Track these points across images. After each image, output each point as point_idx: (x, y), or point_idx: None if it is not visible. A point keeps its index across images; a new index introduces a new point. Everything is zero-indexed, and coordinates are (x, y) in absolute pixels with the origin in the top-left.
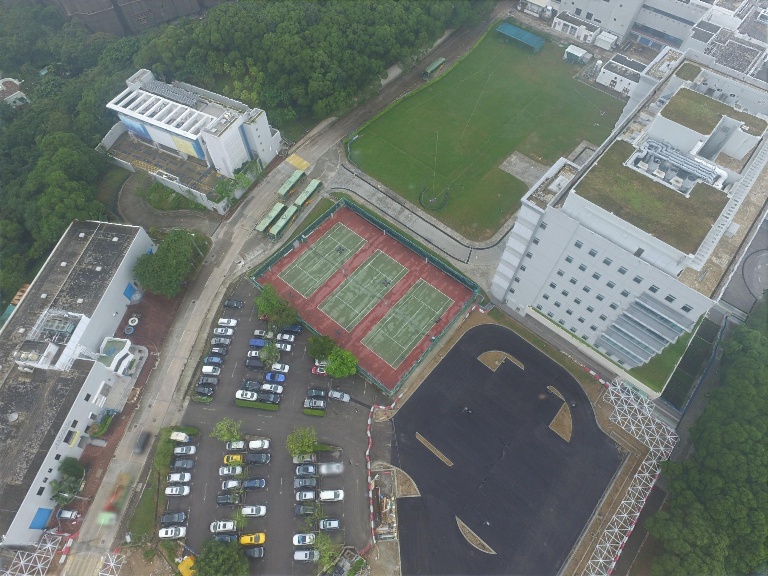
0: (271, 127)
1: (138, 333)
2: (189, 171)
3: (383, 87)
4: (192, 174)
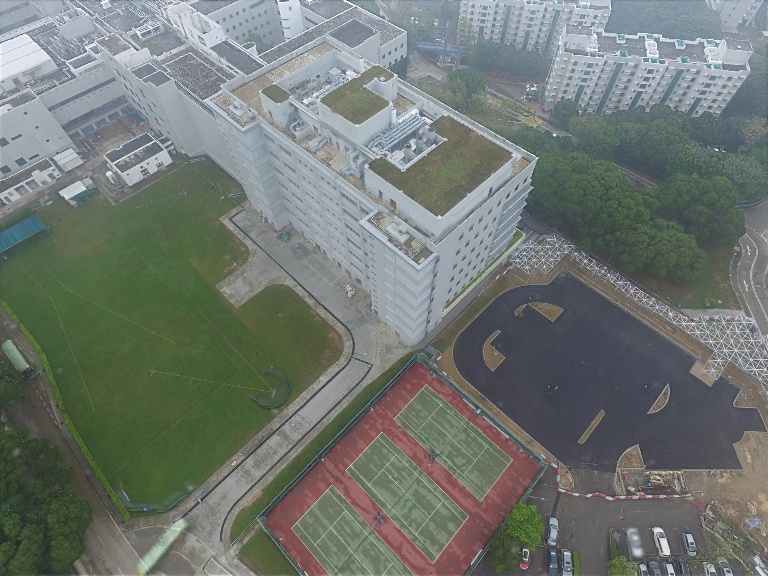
0: None
1: None
2: None
3: None
4: None
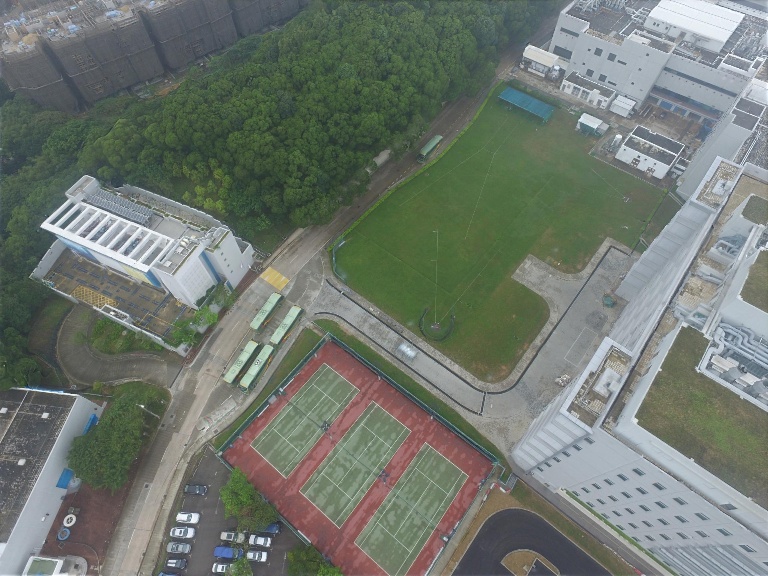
0: (241, 240)
1: (75, 537)
2: (143, 300)
3: (372, 173)
4: (147, 304)
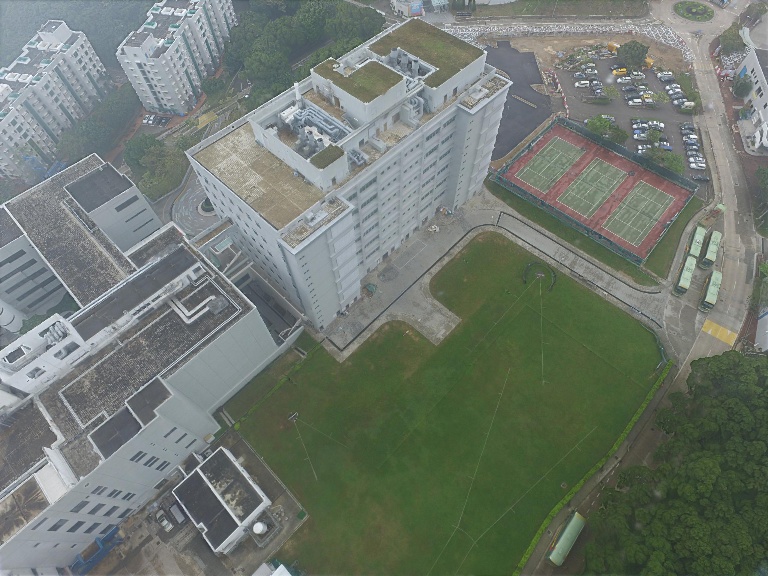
0: None
1: (765, 163)
2: None
3: None
4: None
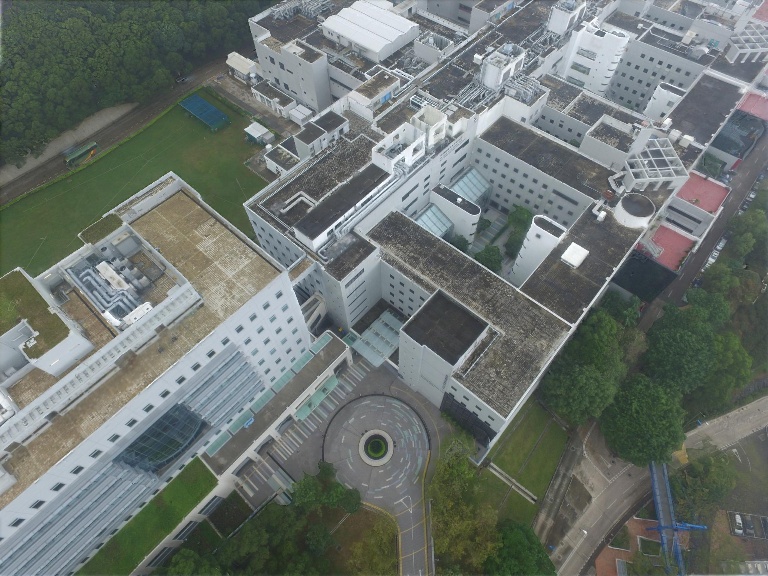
0: None
1: None
2: None
3: (17, 178)
4: None
